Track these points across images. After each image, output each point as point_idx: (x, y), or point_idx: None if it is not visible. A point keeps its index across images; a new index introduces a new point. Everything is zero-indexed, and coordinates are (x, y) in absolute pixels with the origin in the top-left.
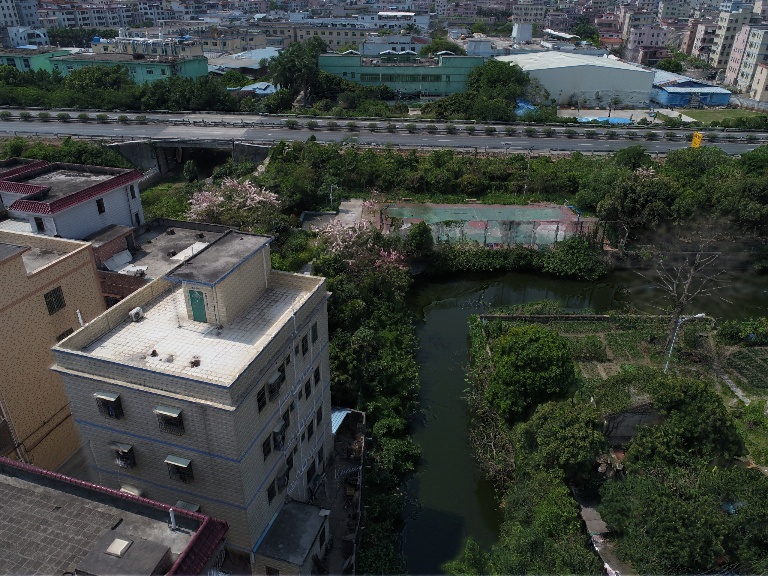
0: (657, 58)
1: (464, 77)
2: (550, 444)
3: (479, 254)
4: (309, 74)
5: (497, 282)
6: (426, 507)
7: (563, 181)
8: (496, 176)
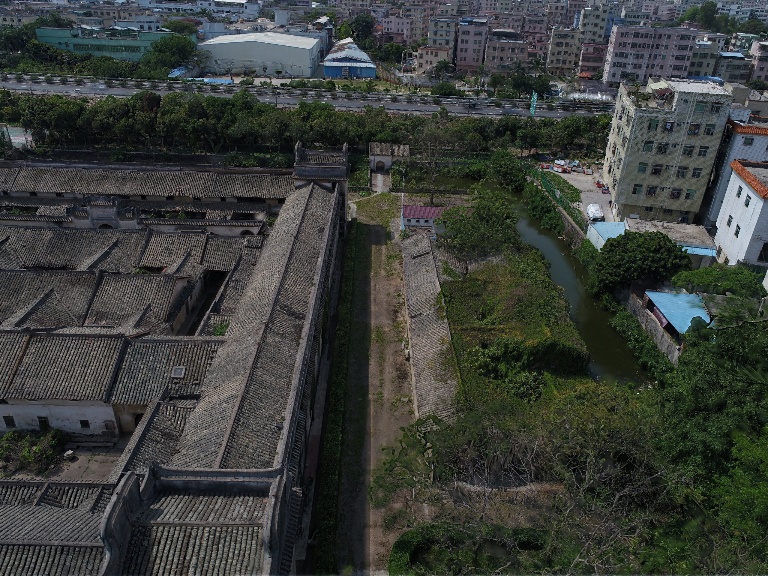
0: None
1: None
2: None
3: None
4: (12, 41)
5: None
6: None
7: None
8: None
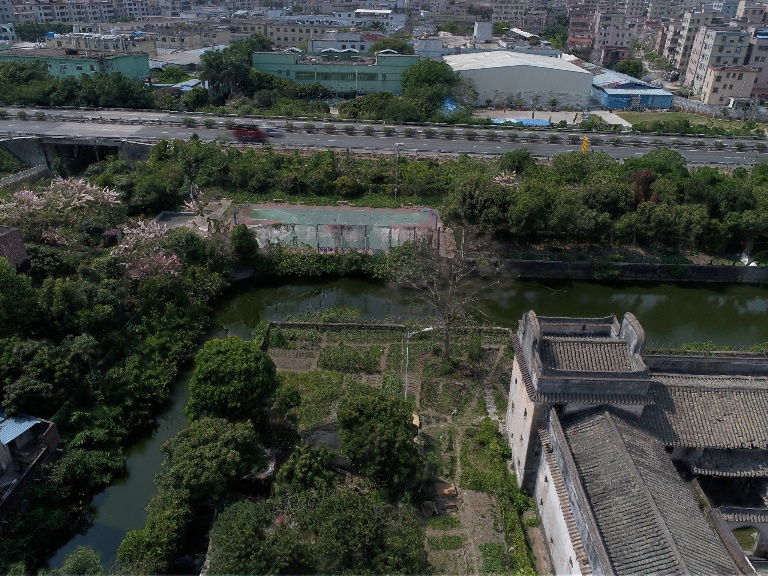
0: (619, 59)
1: (400, 76)
2: (179, 463)
3: (307, 258)
4: (237, 71)
5: (335, 287)
6: (98, 523)
7: (441, 184)
8: (377, 178)
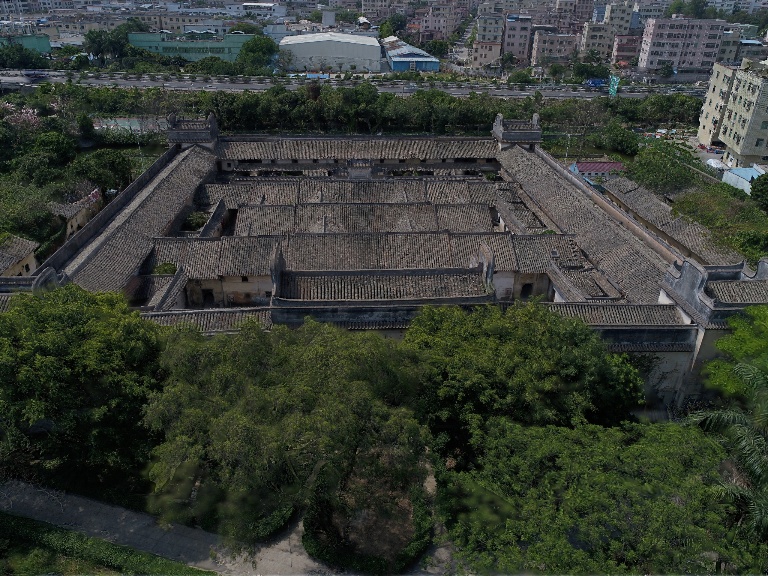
0: (432, 39)
1: None
2: None
3: (123, 134)
4: (114, 46)
5: None
6: None
7: None
8: (188, 104)
